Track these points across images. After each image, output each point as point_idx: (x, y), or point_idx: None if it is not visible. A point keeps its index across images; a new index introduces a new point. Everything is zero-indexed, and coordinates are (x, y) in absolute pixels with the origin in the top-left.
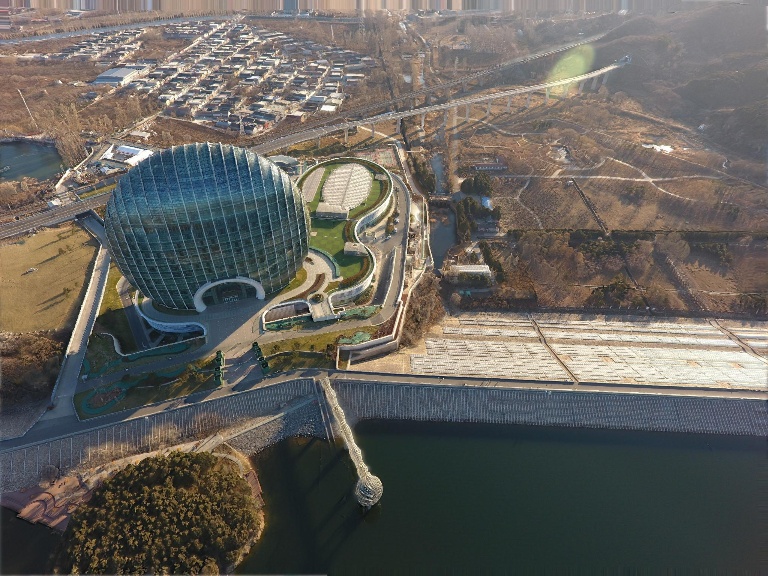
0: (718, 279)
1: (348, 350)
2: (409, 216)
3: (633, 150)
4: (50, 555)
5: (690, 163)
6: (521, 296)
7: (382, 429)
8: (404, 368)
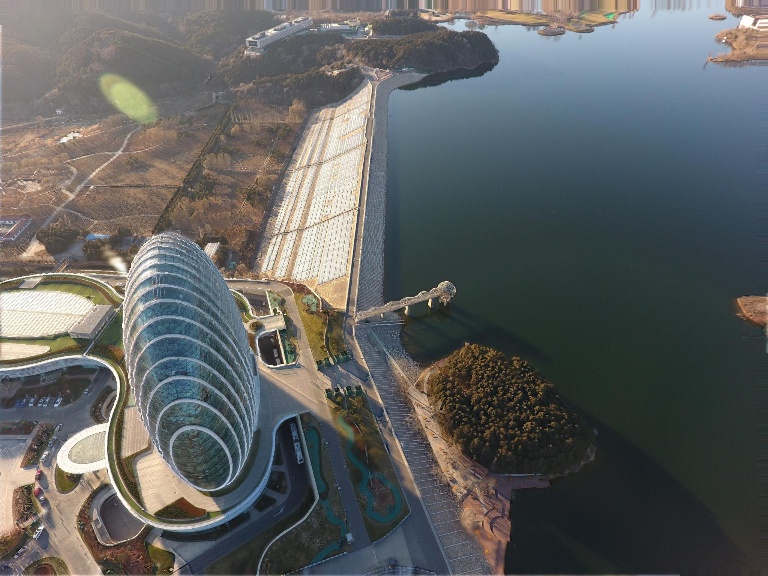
0: (252, 159)
1: (322, 308)
2: (117, 275)
3: (66, 147)
4: (540, 463)
5: (110, 131)
6: (244, 238)
7: (391, 297)
8: (340, 281)
